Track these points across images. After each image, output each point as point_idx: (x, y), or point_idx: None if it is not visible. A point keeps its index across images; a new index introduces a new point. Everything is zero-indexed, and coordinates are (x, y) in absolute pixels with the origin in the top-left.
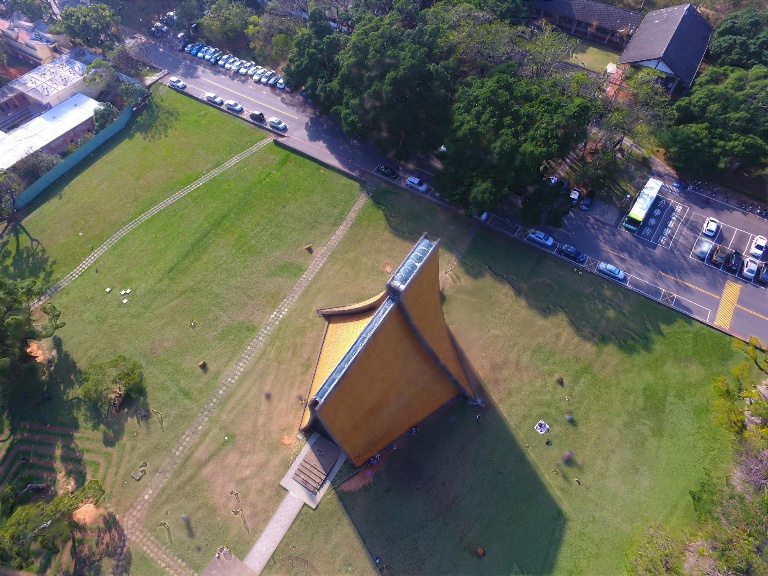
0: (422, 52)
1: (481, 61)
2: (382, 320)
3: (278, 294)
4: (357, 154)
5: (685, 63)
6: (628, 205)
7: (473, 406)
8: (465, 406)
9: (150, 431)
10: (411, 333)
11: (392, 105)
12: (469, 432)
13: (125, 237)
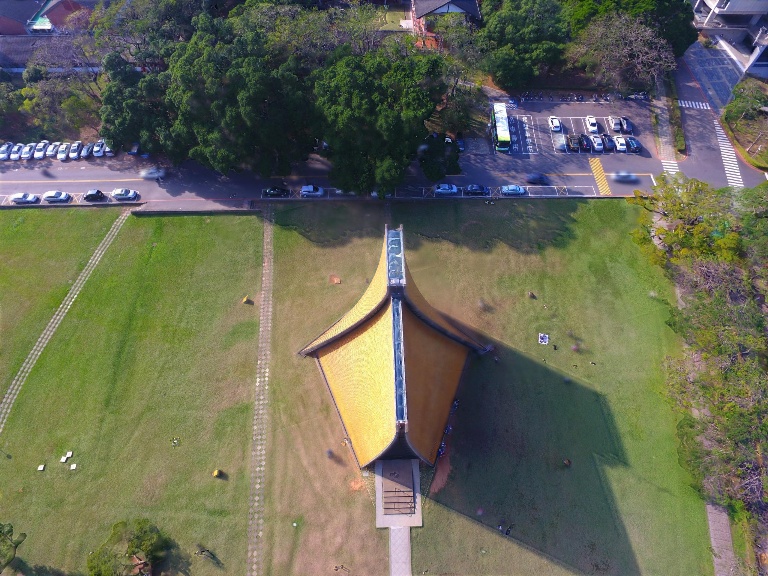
0: (261, 62)
1: (318, 52)
2: (402, 320)
3: (248, 360)
4: (233, 188)
5: (467, 0)
6: (490, 132)
7: (485, 354)
8: (480, 358)
9: (208, 575)
10: (416, 321)
11: (256, 125)
12: (497, 377)
13: (19, 400)
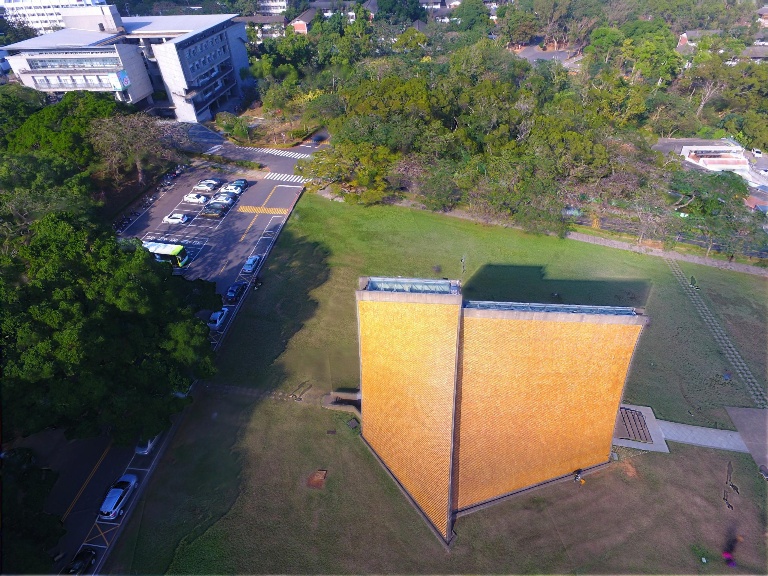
0: None
1: None
2: None
3: None
4: None
5: None
6: None
7: None
8: None
9: None
10: None
11: None
12: None
13: None
